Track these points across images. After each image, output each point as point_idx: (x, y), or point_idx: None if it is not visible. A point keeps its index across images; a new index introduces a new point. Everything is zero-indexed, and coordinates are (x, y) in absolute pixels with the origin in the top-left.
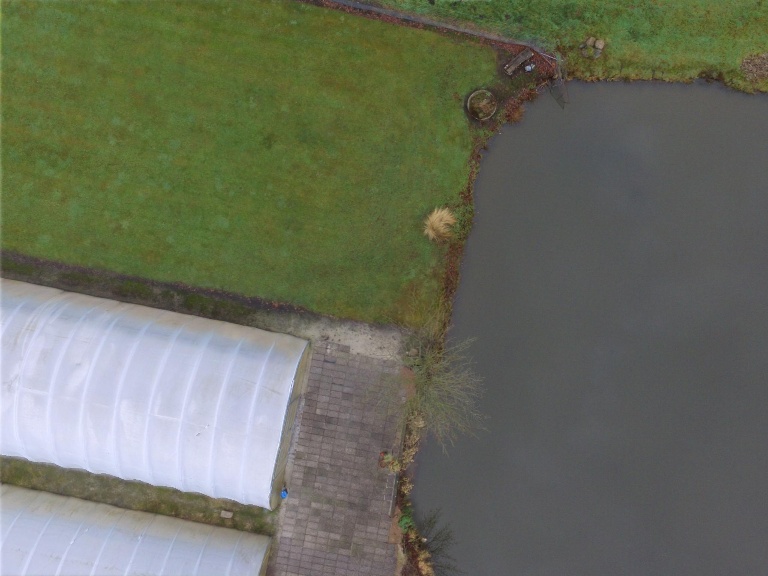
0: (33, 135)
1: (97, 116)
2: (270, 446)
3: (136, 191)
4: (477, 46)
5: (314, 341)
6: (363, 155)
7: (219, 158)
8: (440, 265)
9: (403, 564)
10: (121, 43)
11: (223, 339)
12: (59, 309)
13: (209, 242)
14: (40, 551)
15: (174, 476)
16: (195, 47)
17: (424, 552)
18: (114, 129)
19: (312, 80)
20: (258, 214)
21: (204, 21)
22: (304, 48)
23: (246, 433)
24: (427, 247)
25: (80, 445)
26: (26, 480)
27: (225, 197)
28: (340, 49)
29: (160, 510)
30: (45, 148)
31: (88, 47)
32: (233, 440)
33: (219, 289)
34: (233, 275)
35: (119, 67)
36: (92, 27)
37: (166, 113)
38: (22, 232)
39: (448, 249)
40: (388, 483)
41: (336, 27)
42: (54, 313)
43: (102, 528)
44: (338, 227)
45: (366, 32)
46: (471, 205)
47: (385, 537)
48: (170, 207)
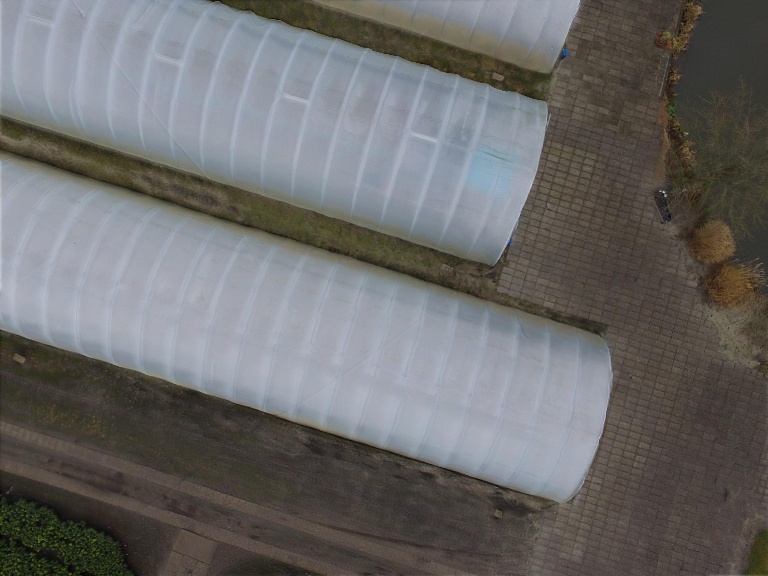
0: None
1: None
2: None
3: None
4: None
5: None
6: None
7: None
8: None
9: (667, 148)
10: None
11: None
12: None
13: None
14: (337, 52)
15: None
16: None
17: (688, 141)
18: None
19: None
20: None
21: None
22: None
23: None
24: None
25: None
26: (301, 22)
27: None
28: None
29: (432, 65)
30: None
31: None
32: None
33: None
34: None
35: None
36: None
37: None
38: None
39: None
40: (661, 64)
41: None
42: None
43: (388, 55)
44: None
45: None
46: None
47: (653, 118)
48: None
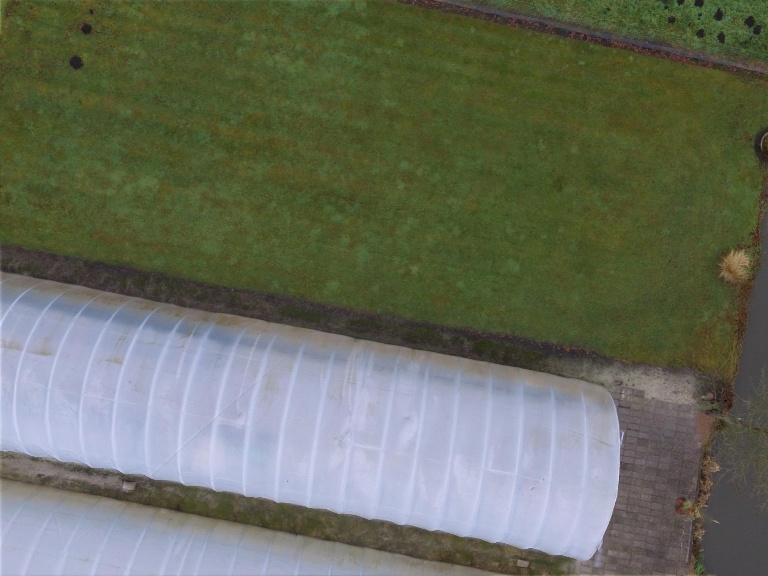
0: (320, 181)
1: (385, 161)
2: (606, 500)
3: (426, 236)
4: (767, 85)
5: (608, 386)
6: (653, 197)
7: (509, 202)
8: (732, 307)
9: None
10: (408, 86)
11: (524, 386)
12: (369, 360)
13: (500, 287)
14: None
15: (498, 530)
16: (483, 89)
17: None
18: (402, 173)
19: (602, 121)
20: (549, 258)
21: (492, 63)
22: (593, 89)
23: (582, 487)
24: (719, 289)
25: (408, 500)
26: (319, 531)
27: (516, 241)
28: (629, 89)
29: (455, 560)
30: (332, 194)
31: (375, 91)
32: (568, 494)
33: (510, 334)
34: (524, 320)
35: (406, 111)
36: (378, 70)
37: (455, 157)
38: (310, 279)
39: (739, 291)
40: (685, 529)
41: (624, 67)
42: (367, 364)
43: None
44: (630, 270)
45: (655, 72)
46: (758, 245)
47: None
48: (460, 252)
